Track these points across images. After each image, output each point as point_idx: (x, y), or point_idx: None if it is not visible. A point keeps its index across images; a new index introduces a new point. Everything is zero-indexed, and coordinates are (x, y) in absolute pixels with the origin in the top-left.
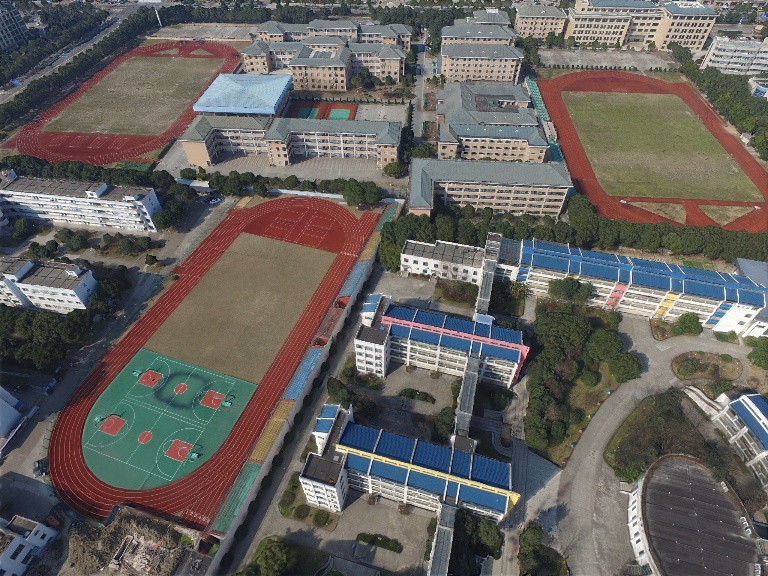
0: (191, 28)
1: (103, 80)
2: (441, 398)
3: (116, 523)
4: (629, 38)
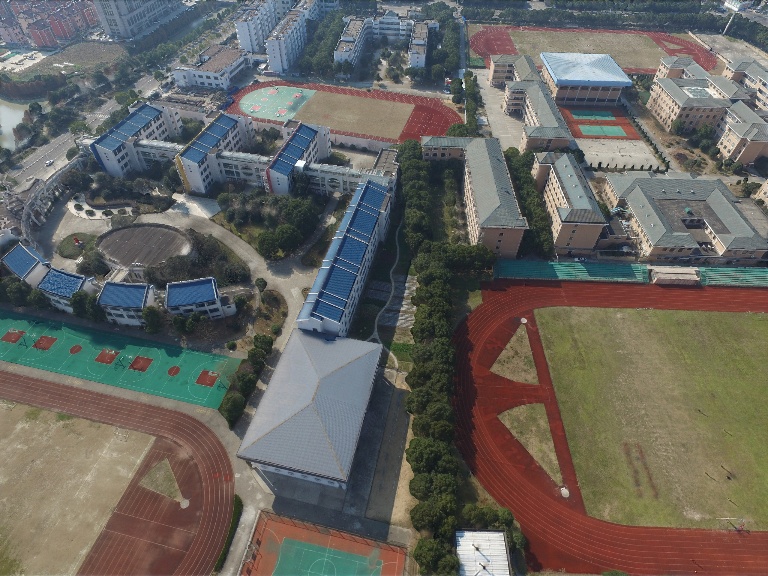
0: (738, 46)
1: (594, 33)
2: None
3: (224, 97)
4: None
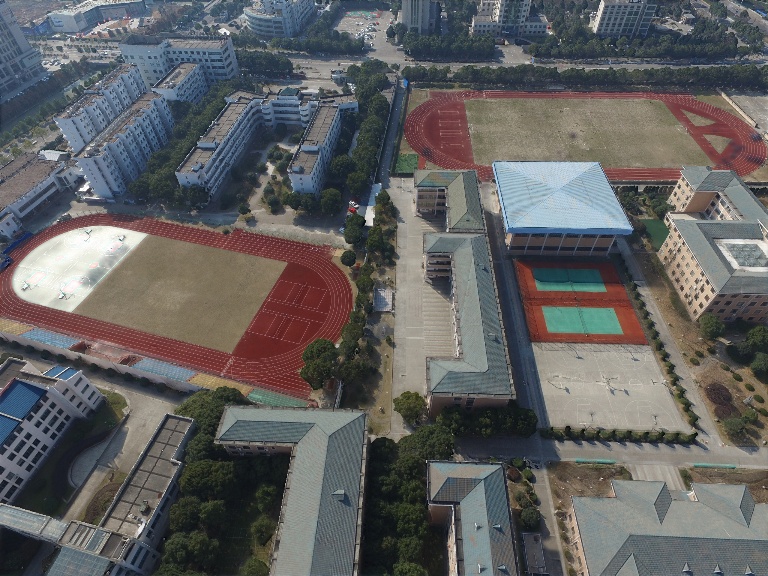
0: None
1: (585, 100)
2: None
3: None
4: None
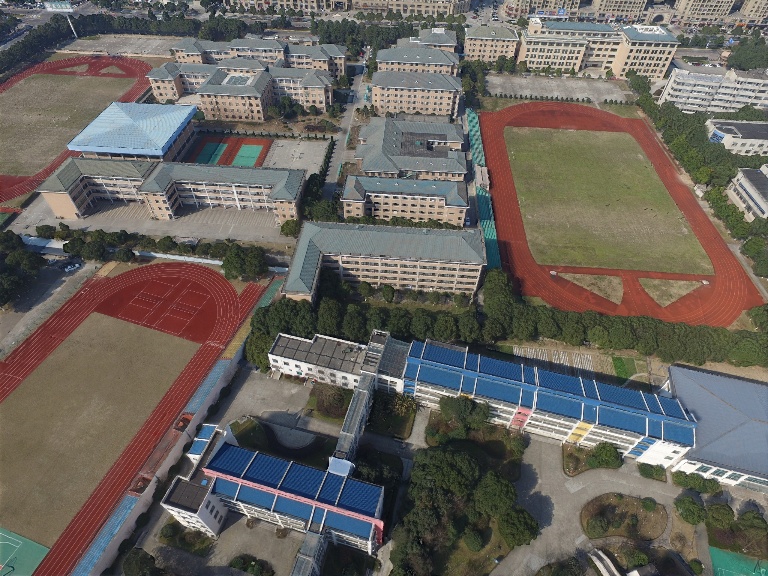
0: (110, 40)
1: None
2: (282, 570)
3: None
4: (586, 63)
